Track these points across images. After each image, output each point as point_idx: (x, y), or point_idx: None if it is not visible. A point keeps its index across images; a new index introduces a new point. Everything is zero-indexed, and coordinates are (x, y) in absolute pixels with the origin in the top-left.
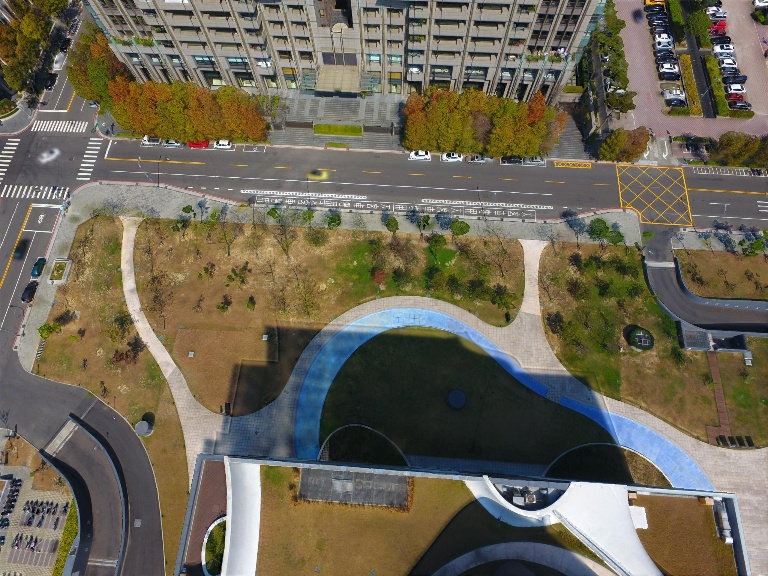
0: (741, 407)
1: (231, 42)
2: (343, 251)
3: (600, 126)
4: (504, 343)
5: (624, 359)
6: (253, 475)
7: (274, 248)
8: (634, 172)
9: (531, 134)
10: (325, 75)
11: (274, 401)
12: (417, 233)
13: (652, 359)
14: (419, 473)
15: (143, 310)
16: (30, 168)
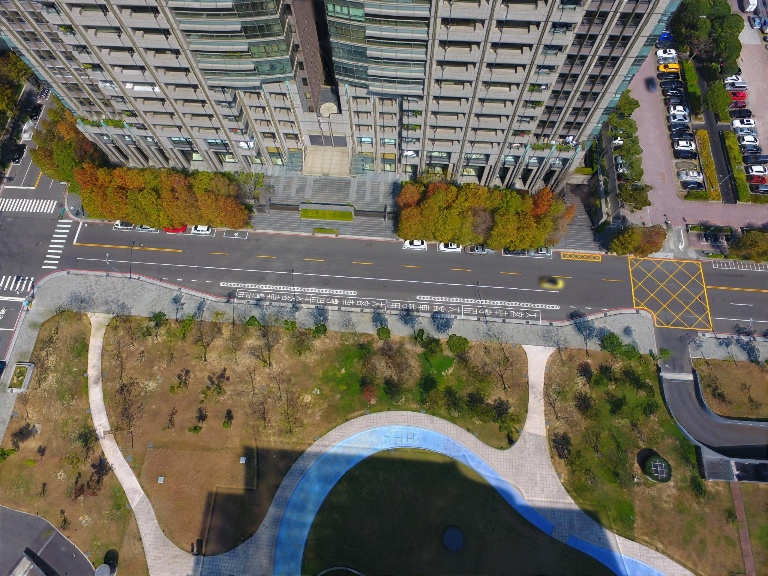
0: None
1: (209, 126)
2: (330, 357)
3: (611, 214)
4: (506, 469)
5: (638, 490)
6: None
7: (255, 352)
8: (648, 266)
9: (536, 230)
10: (312, 157)
11: (251, 538)
12: (411, 336)
13: (669, 491)
14: None
15: (107, 433)
16: None
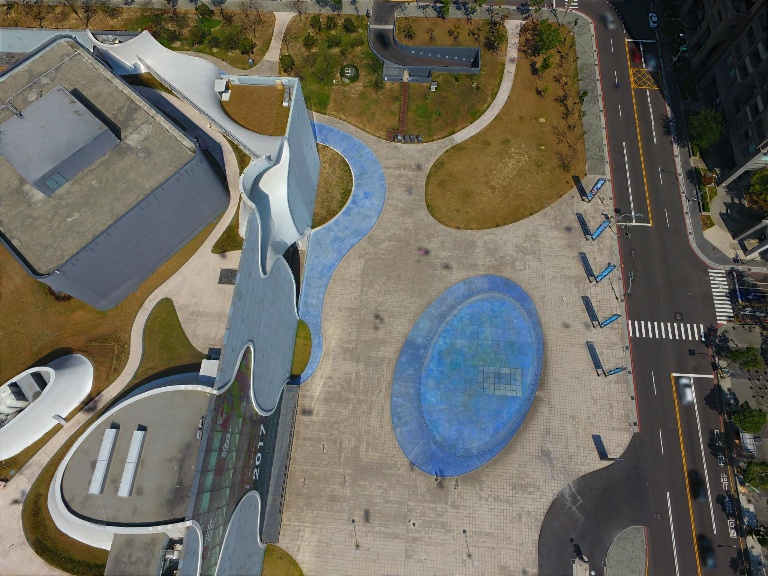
0: (419, 117)
1: None
2: (132, 22)
3: None
4: None
5: (335, 88)
6: None
7: (77, 21)
8: None
9: None
10: None
11: None
12: (193, 9)
13: (358, 88)
14: None
15: None
16: None
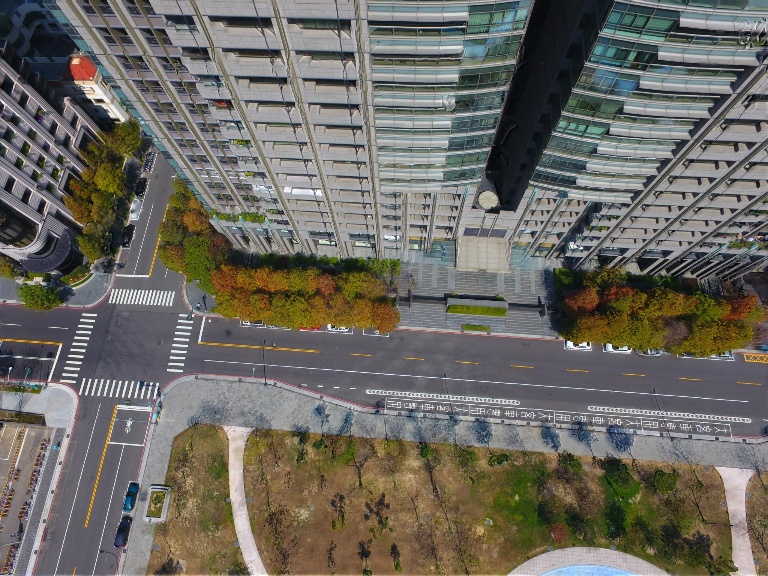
0: None
1: (361, 223)
2: (500, 480)
3: None
4: None
5: None
6: None
7: (415, 475)
8: None
9: None
10: (466, 250)
11: None
12: (588, 456)
13: None
14: None
15: None
16: (111, 355)
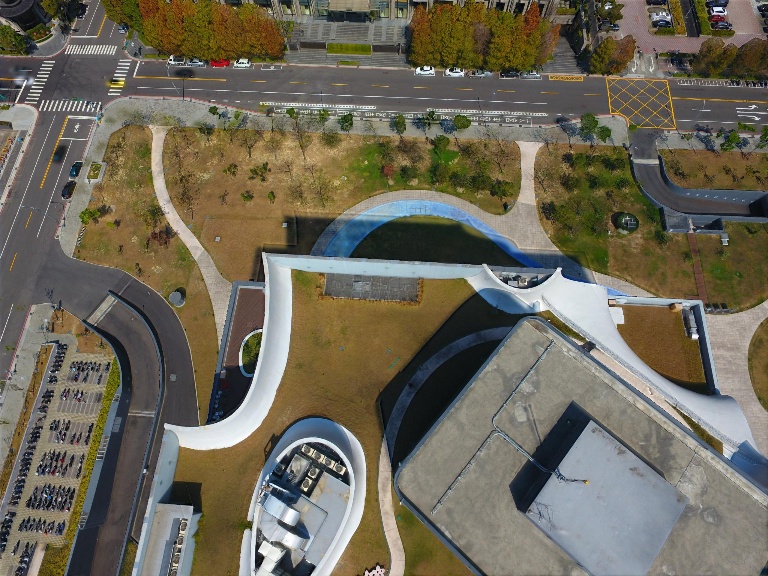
0: (717, 279)
1: None
2: (355, 153)
3: (591, 43)
4: (502, 228)
5: (612, 240)
6: (285, 276)
7: (291, 151)
8: (623, 84)
9: (527, 45)
10: None
11: None
12: (423, 137)
13: (637, 240)
14: (428, 263)
15: (174, 197)
16: (65, 86)
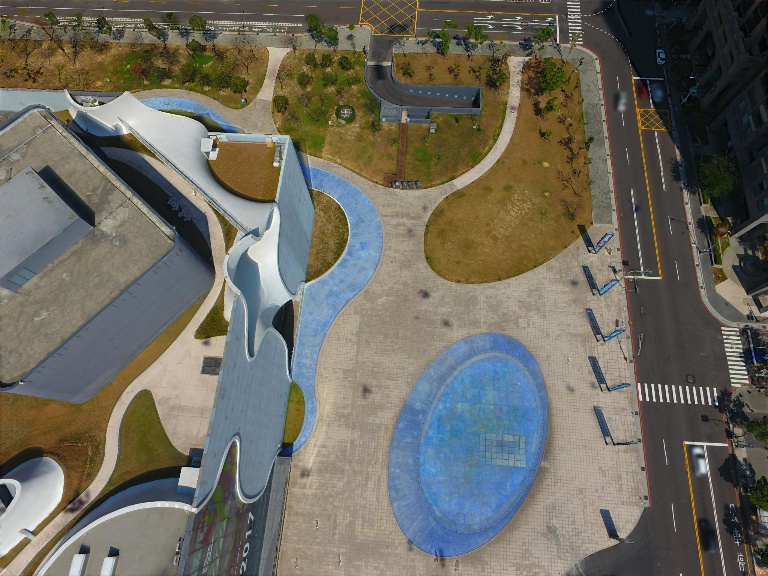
0: (417, 161)
1: None
2: (121, 58)
3: None
4: (237, 120)
5: (331, 129)
6: None
7: (64, 57)
8: None
9: None
10: None
11: None
12: (184, 44)
13: (354, 129)
14: (19, 89)
15: None
16: None
